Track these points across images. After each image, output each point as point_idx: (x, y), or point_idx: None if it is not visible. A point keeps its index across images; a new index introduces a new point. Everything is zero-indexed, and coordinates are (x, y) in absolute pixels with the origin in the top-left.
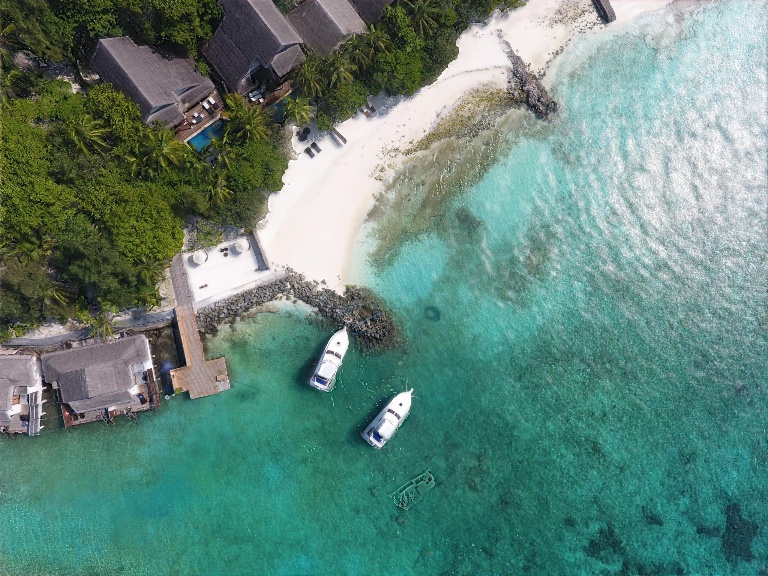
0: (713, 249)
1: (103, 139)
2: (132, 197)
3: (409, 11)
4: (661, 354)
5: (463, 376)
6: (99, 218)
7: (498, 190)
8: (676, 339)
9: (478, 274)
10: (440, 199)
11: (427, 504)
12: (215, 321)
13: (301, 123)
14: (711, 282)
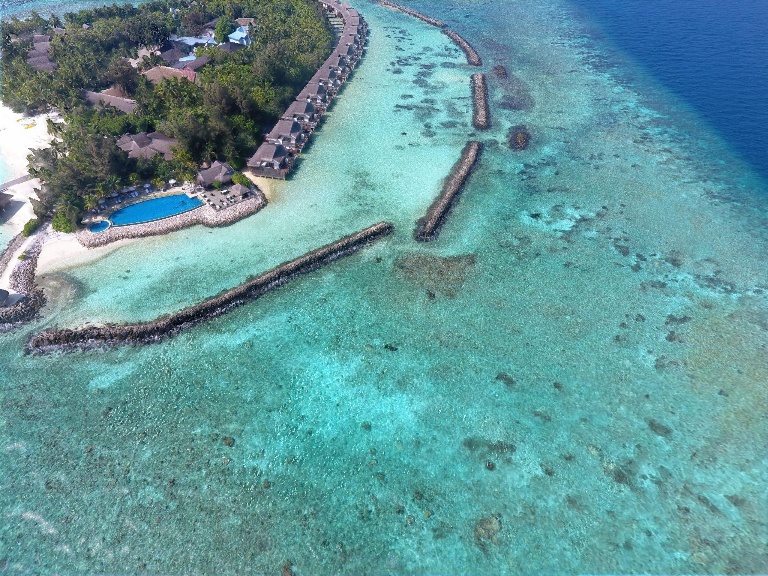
0: None
1: None
2: None
3: (156, 2)
4: (110, 1)
5: None
6: None
7: None
8: None
9: None
10: None
11: None
12: None
13: None
14: None
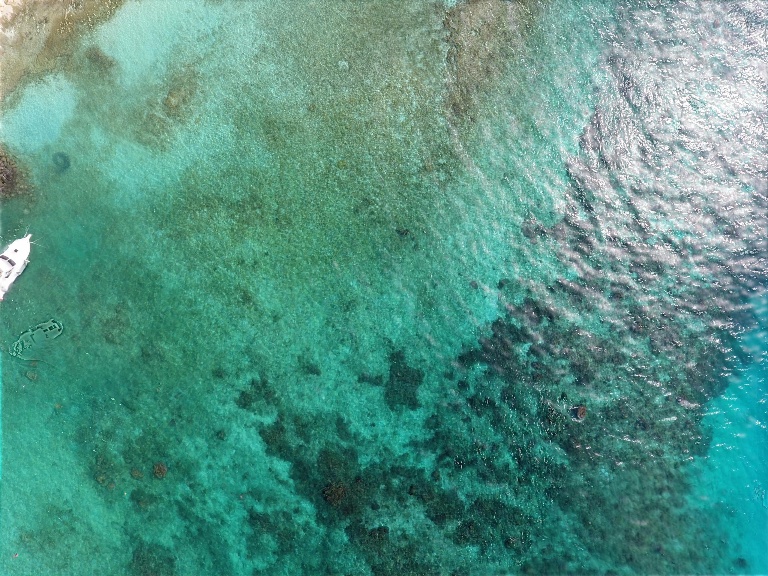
0: (372, 88)
1: None
2: None
3: None
4: (317, 198)
5: (98, 225)
6: None
7: (132, 28)
8: (333, 183)
9: (112, 117)
10: (66, 37)
11: (60, 358)
12: None
13: None
14: (370, 122)
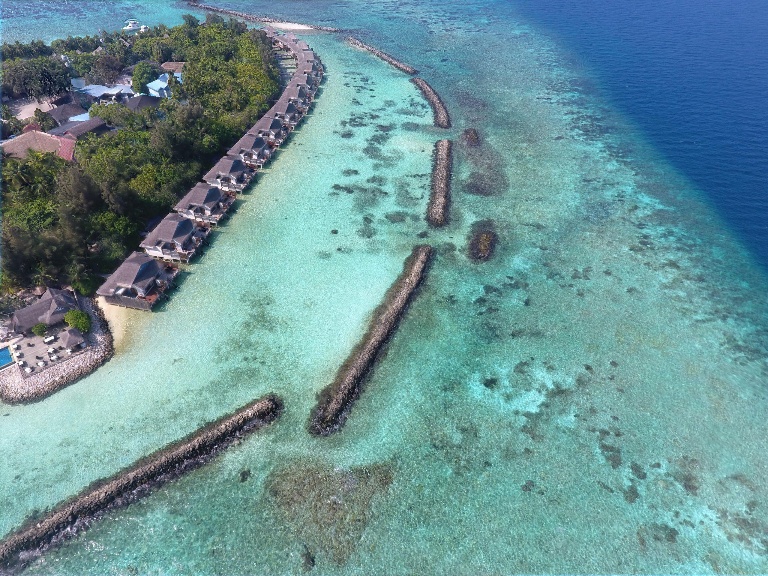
0: None
1: None
2: (178, 28)
3: None
4: None
5: None
6: None
7: None
8: None
9: None
10: None
11: None
12: None
13: None
14: None
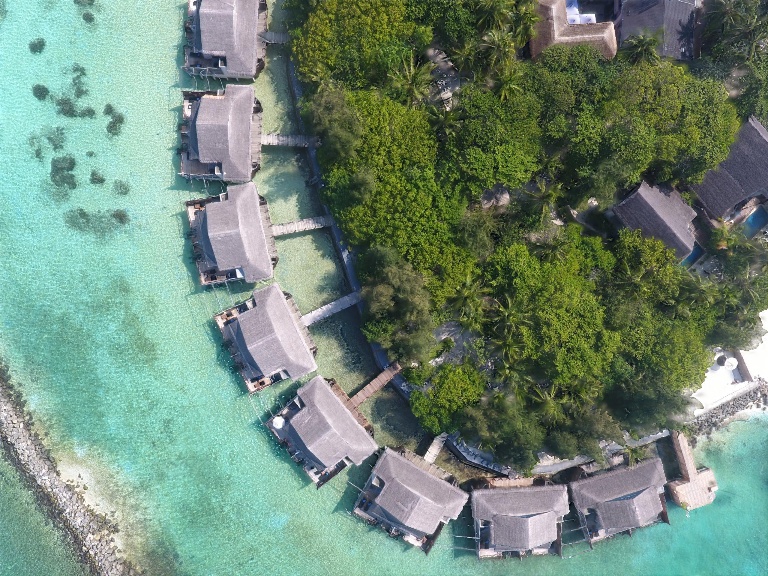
0: None
1: None
2: (681, 339)
3: None
4: None
5: None
6: (641, 359)
7: None
8: None
9: None
10: None
11: None
12: (695, 434)
13: None
14: None
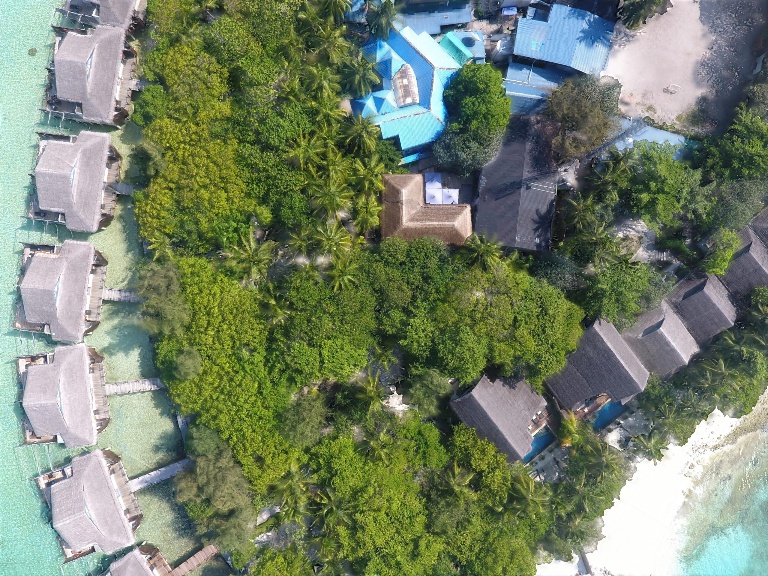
0: None
1: (470, 487)
2: (504, 550)
3: (766, 354)
4: None
5: None
6: (465, 563)
7: None
8: None
9: None
10: (746, 493)
11: None
12: None
13: (651, 459)
14: None
